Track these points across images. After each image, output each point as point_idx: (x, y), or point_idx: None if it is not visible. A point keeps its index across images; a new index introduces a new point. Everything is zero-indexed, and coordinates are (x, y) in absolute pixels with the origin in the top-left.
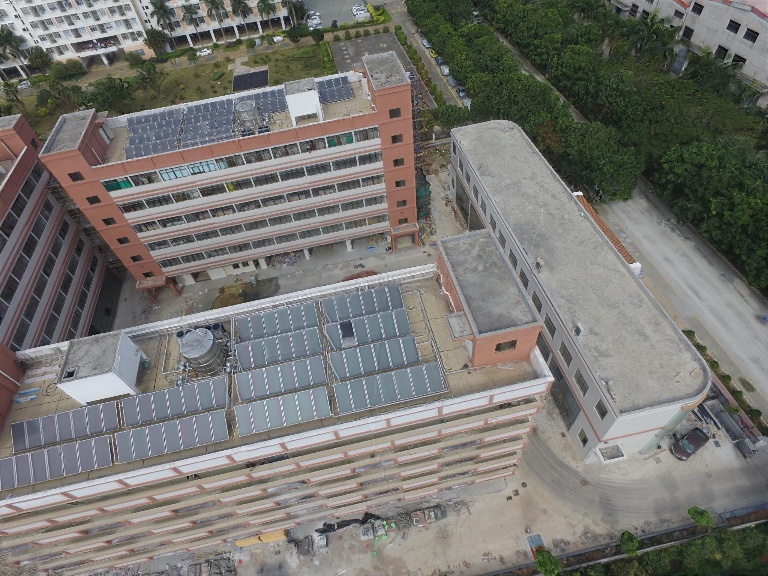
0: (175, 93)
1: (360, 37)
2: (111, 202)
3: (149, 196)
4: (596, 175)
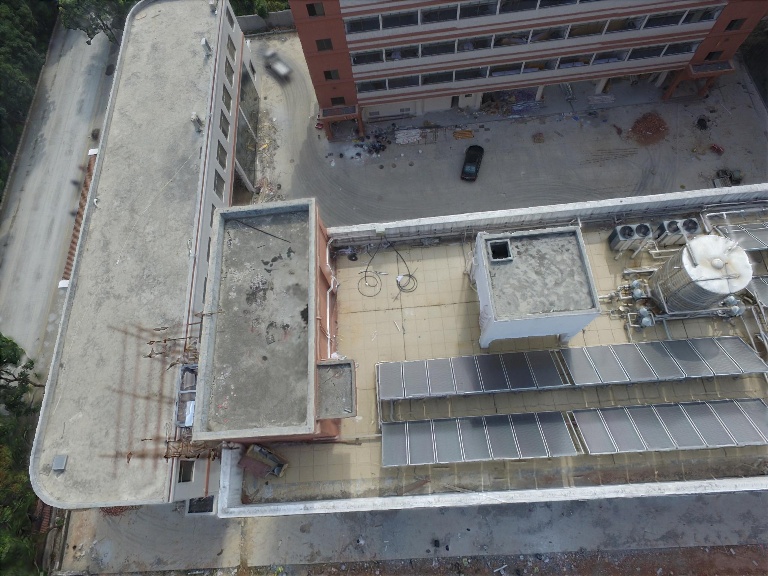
0: None
1: None
2: None
3: None
4: (5, 352)
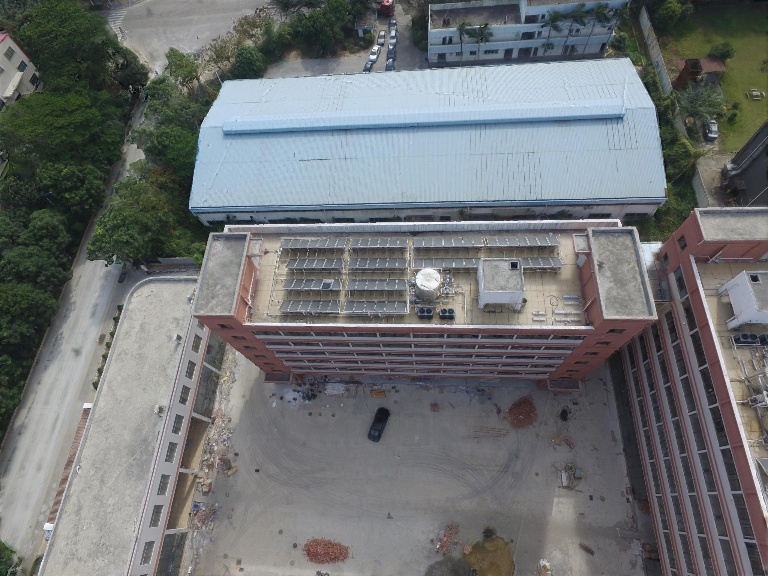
0: None
1: None
2: None
3: None
4: None
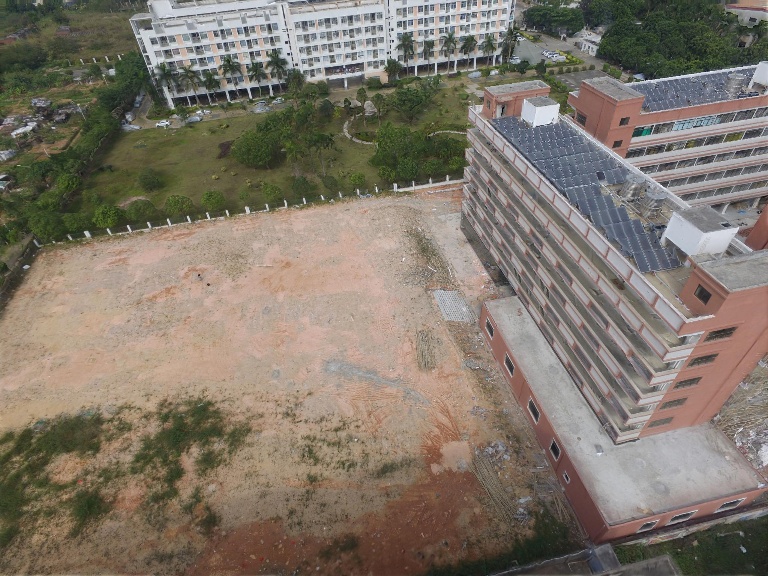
0: (434, 108)
1: (571, 72)
2: (627, 147)
3: (654, 144)
4: None
